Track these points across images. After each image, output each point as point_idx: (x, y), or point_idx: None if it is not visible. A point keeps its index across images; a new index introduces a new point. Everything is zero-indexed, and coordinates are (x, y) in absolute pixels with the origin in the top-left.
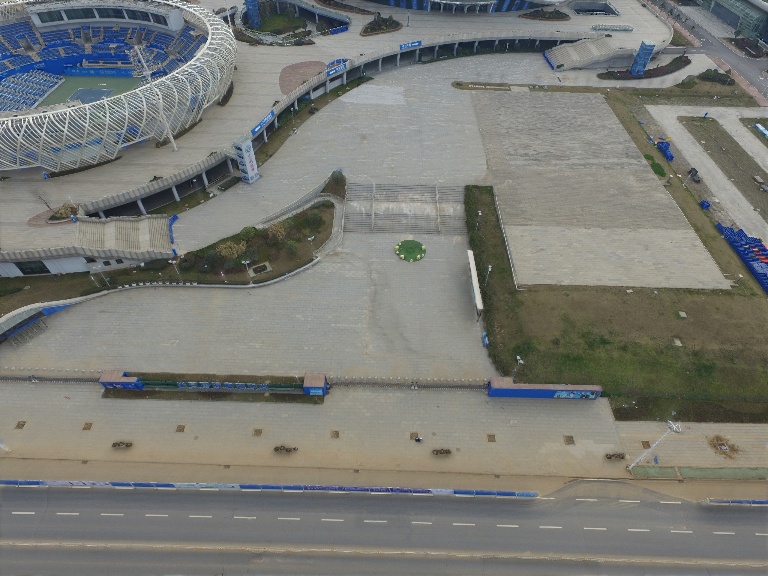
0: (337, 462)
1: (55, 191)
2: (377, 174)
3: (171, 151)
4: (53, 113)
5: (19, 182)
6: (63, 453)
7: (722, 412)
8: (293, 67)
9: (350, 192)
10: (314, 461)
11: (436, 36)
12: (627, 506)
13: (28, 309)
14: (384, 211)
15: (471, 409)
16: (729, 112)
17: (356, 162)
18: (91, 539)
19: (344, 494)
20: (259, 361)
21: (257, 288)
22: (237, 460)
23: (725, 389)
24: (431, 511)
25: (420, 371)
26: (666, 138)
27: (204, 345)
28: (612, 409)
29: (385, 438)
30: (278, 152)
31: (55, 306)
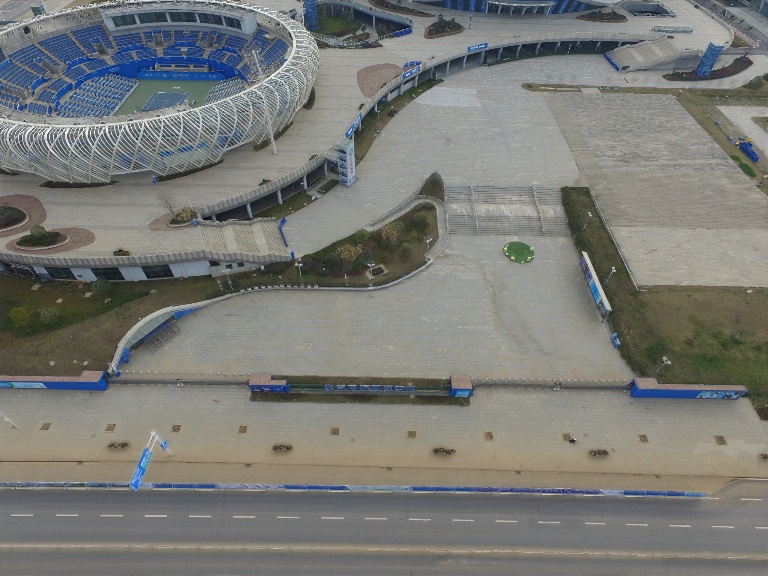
0: (497, 463)
1: (167, 195)
2: (471, 176)
3: (271, 154)
4: (166, 117)
5: (129, 186)
6: (225, 456)
7: None
8: (368, 70)
9: (448, 194)
10: (474, 463)
11: (501, 38)
12: None
13: (162, 313)
14: (485, 213)
15: (617, 410)
16: None
17: (447, 164)
18: (273, 542)
19: (515, 495)
20: (397, 363)
21: (377, 290)
22: (398, 462)
23: None
24: (602, 512)
25: (558, 372)
26: (746, 139)
27: (339, 348)
28: (755, 409)
29: (539, 439)
30: (368, 155)
31: (184, 310)
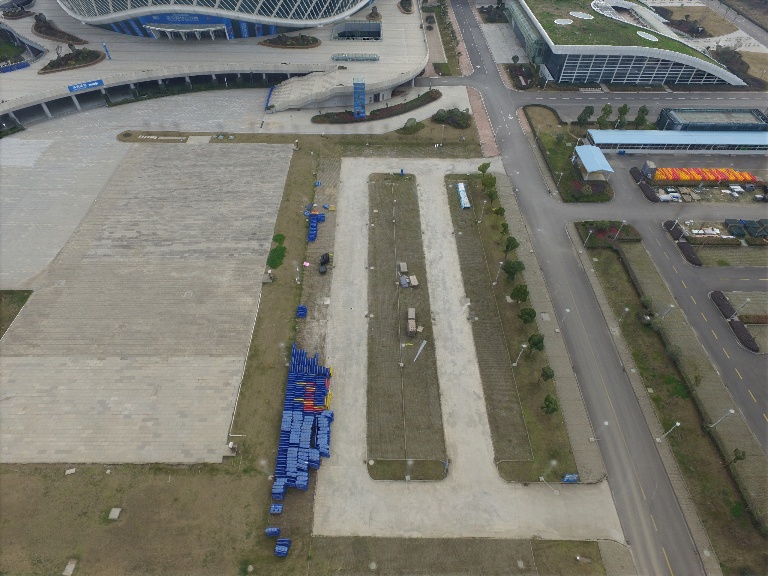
0: None
1: None
2: None
3: None
4: None
5: None
6: None
7: None
8: None
9: None
10: None
11: None
12: None
13: None
14: None
15: None
16: (440, 166)
17: None
18: None
19: None
20: None
21: None
22: None
23: None
24: None
25: None
26: None
27: None
28: None
29: None
30: None
31: None
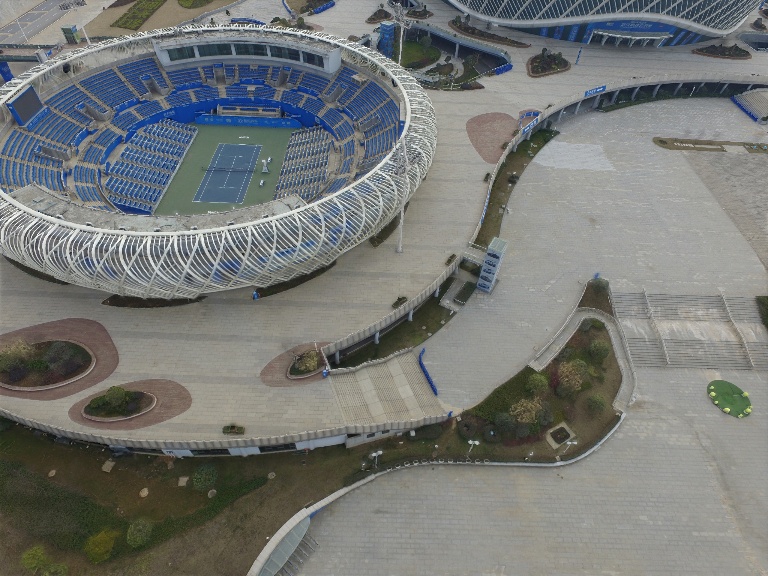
0: None
1: (275, 321)
2: (638, 278)
3: (394, 252)
4: (277, 218)
5: (222, 305)
6: None
7: None
8: (477, 121)
9: (616, 305)
10: None
11: (618, 79)
12: None
13: (296, 523)
14: (670, 335)
15: None
16: None
17: (603, 258)
18: None
19: None
20: None
21: (566, 466)
22: None
23: None
24: None
25: None
26: None
27: (542, 575)
28: None
29: None
30: None
31: (319, 508)
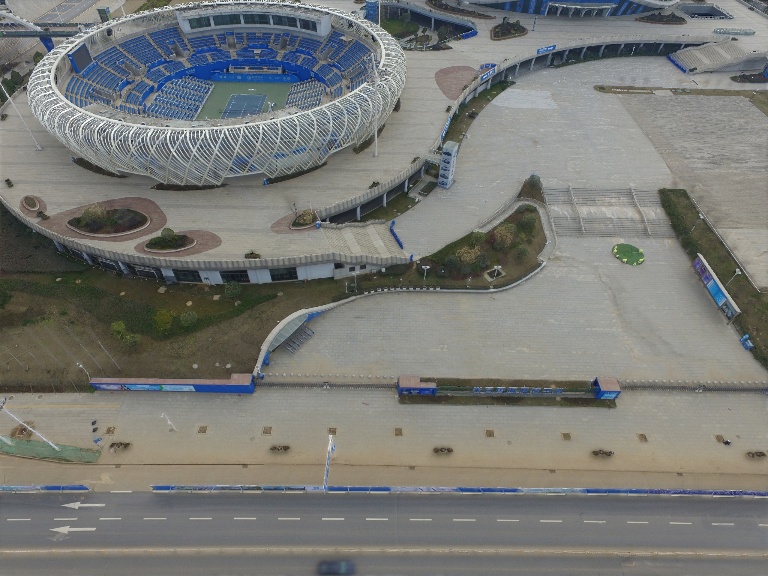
0: (658, 465)
1: (281, 197)
2: (567, 178)
3: (372, 156)
4: (281, 120)
5: (240, 188)
6: (387, 459)
7: None
8: (444, 72)
9: (547, 196)
10: (635, 465)
11: (567, 40)
12: None
13: (298, 315)
14: (588, 215)
15: (763, 411)
16: None
17: (540, 166)
18: (456, 545)
19: (686, 497)
20: (535, 365)
21: (498, 293)
22: (559, 464)
23: None
24: None
25: (696, 374)
26: None
27: (474, 350)
28: None
29: (693, 441)
30: (459, 157)
31: (315, 312)
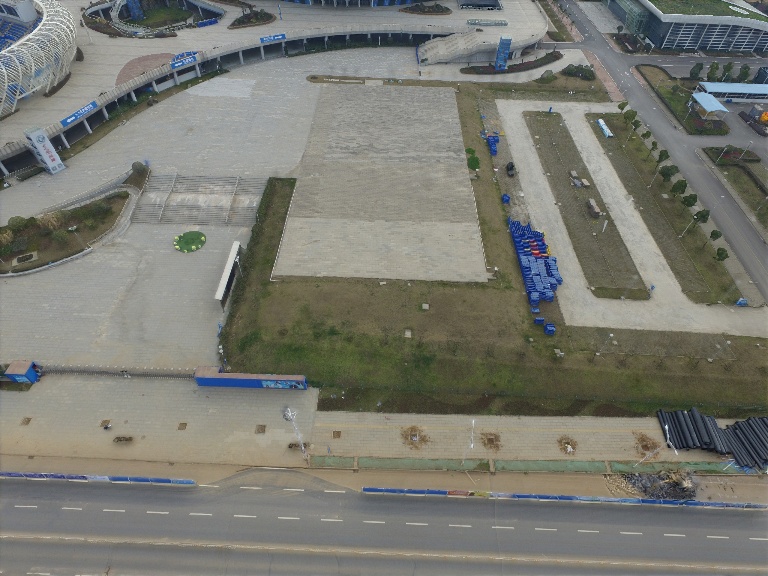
0: (15, 448)
1: None
2: (186, 166)
3: None
4: None
5: None
6: None
7: (429, 403)
8: (141, 59)
9: (151, 183)
10: None
11: (303, 29)
12: (288, 494)
13: None
14: (178, 202)
15: (175, 398)
16: (578, 107)
17: (170, 154)
18: None
19: (0, 479)
20: None
21: (16, 277)
22: None
23: (439, 381)
24: (86, 497)
25: (141, 360)
26: (501, 132)
27: None
28: (318, 399)
29: (75, 425)
30: (96, 143)
31: None
